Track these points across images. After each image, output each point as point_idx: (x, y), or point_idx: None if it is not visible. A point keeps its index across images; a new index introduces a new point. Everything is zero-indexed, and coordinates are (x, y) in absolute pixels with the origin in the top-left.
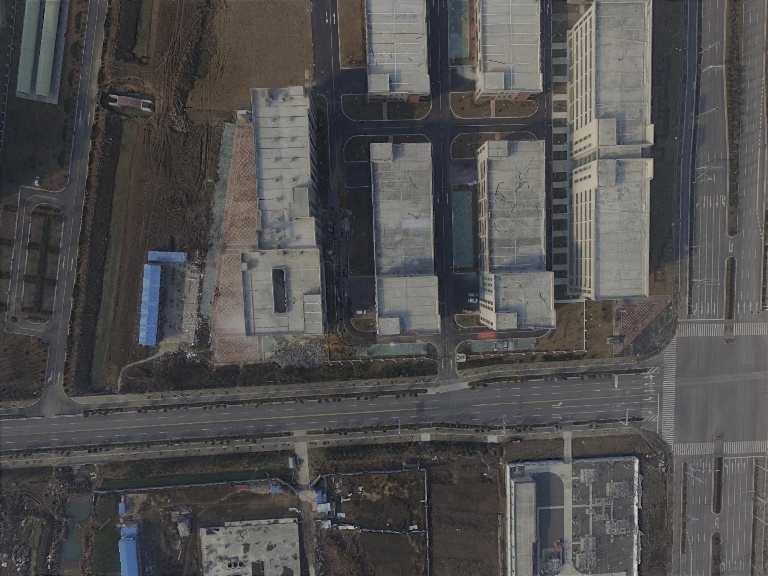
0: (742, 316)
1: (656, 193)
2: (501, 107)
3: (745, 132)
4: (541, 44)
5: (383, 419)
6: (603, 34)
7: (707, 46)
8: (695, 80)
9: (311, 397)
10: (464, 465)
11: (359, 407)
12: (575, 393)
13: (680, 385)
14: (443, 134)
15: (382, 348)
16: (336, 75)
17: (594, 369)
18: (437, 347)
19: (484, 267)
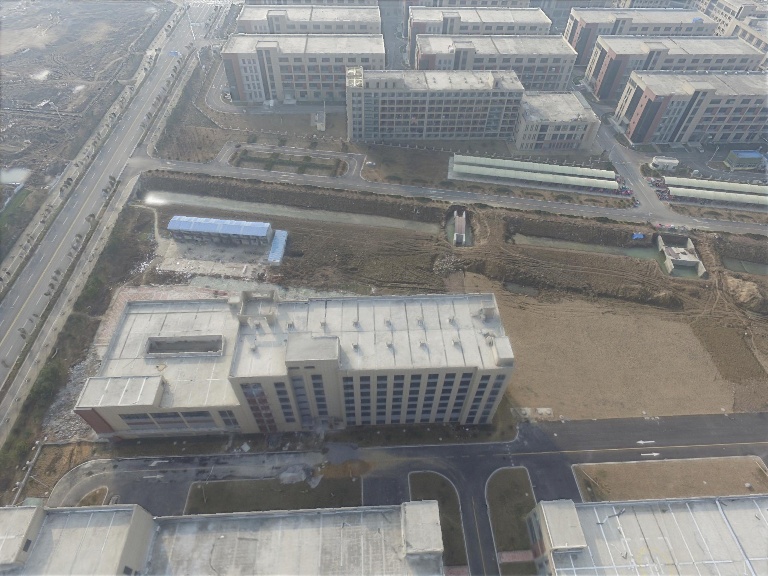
0: None
1: None
2: None
3: None
4: None
5: None
6: None
7: None
8: None
9: None
10: None
11: None
12: None
13: None
14: None
15: None
16: (557, 457)
17: None
18: None
19: None
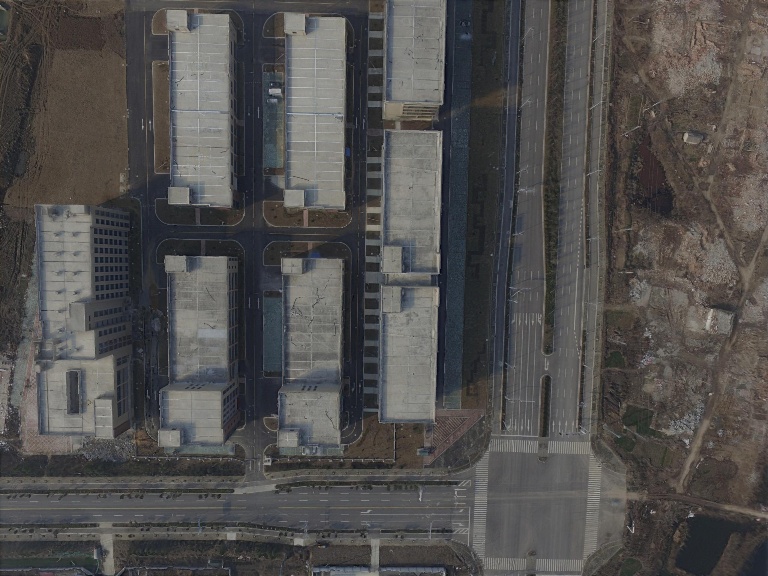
0: (557, 434)
1: (470, 308)
2: (314, 217)
3: (563, 252)
4: (356, 157)
5: (189, 516)
6: (394, 162)
7: (525, 166)
8: (512, 199)
9: (118, 490)
10: (270, 566)
11: (166, 503)
12: (384, 501)
13: (492, 499)
14: (256, 241)
15: (190, 446)
16: (150, 180)
17: (404, 479)
18: (245, 448)
19: None
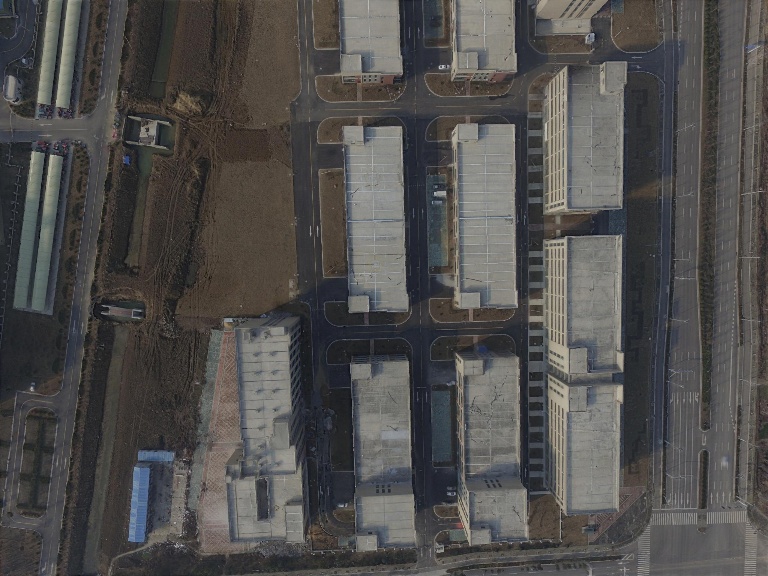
0: (715, 506)
1: (630, 391)
2: (479, 312)
3: (718, 332)
4: (518, 252)
5: None
6: (575, 266)
7: (680, 252)
8: (669, 284)
9: None
10: None
11: None
12: None
13: (654, 571)
14: (423, 337)
15: None
16: (319, 284)
17: (570, 556)
18: None
19: (461, 470)
